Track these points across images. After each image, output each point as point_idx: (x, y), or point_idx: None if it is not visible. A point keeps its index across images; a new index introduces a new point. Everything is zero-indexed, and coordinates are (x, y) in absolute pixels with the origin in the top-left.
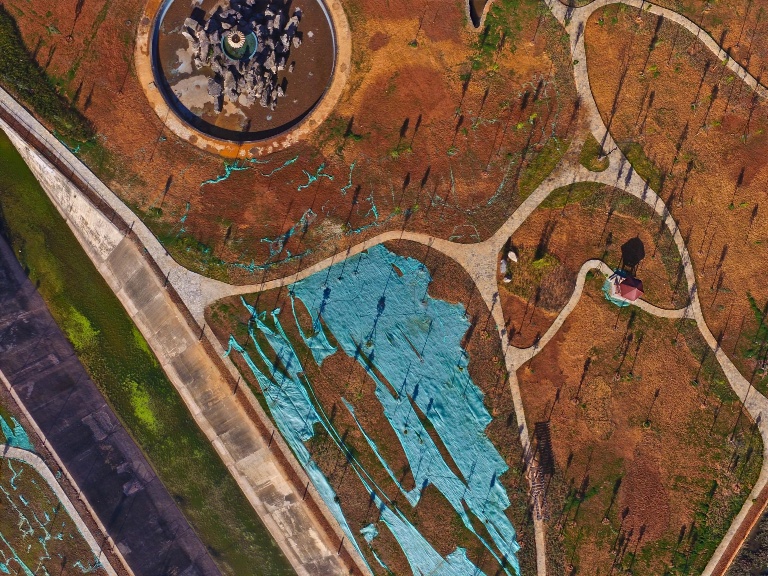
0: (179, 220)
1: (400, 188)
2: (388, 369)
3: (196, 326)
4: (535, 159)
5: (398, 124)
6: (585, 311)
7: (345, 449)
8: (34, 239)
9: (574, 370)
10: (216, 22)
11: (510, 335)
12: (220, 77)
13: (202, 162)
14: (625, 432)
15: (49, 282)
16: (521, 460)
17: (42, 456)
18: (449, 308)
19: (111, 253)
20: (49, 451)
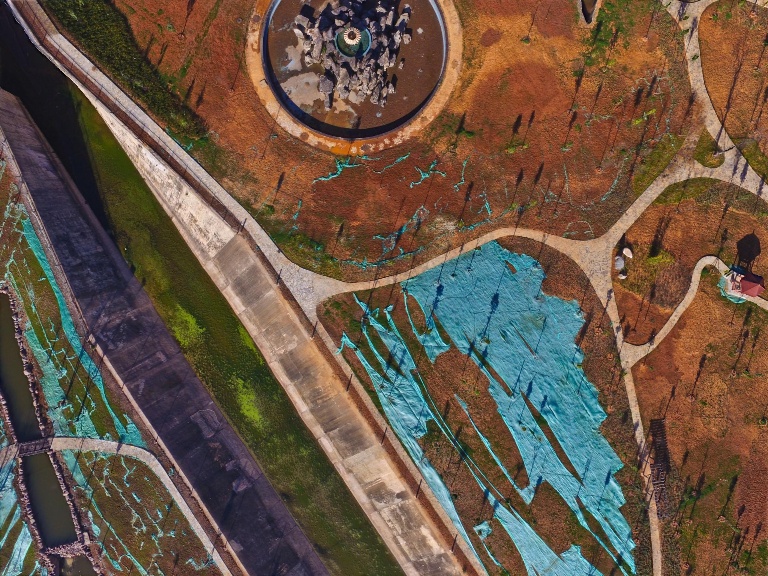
0: (291, 217)
1: (513, 185)
2: (502, 366)
3: (308, 323)
4: (649, 155)
5: (511, 120)
6: (701, 308)
7: (459, 446)
8: (140, 237)
9: (689, 367)
10: (327, 19)
11: (625, 332)
12: (331, 74)
13: (313, 159)
14: (741, 429)
15: (155, 280)
16: (636, 457)
17: (155, 453)
18: (563, 305)
19: (220, 250)
20: (161, 448)
